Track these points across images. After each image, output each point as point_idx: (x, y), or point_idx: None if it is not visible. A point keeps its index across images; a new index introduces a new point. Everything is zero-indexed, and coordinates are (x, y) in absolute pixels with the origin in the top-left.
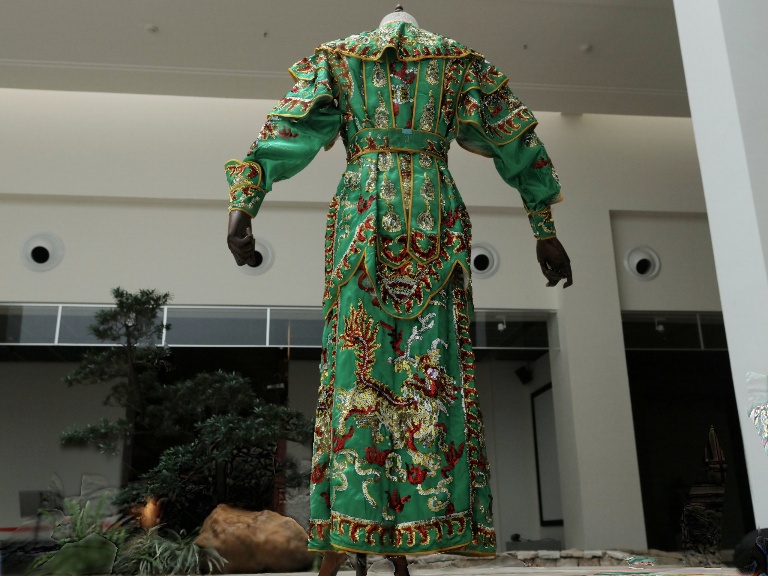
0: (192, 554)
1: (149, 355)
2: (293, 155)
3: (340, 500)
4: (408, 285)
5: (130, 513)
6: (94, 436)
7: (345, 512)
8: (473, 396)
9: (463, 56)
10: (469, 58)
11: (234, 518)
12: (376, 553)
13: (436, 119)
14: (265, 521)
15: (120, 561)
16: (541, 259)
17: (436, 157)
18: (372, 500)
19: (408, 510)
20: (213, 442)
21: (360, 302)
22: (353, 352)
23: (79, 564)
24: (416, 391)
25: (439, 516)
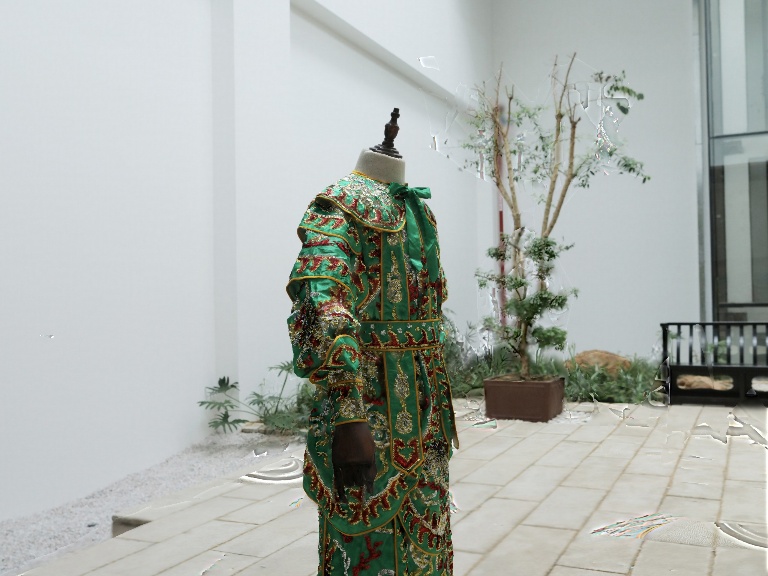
0: None
1: None
2: None
3: None
4: None
5: None
6: None
7: None
8: None
9: None
10: None
11: None
12: None
13: None
14: None
15: None
16: None
17: None
18: None
19: None
20: None
21: None
22: None
23: None
24: None
25: None
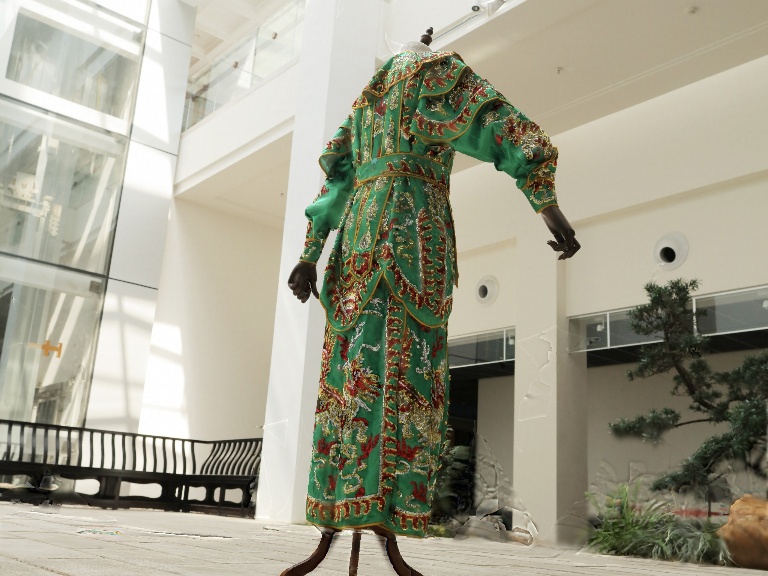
0: (704, 543)
1: (681, 344)
2: (322, 208)
3: None
4: None
5: (663, 499)
6: (639, 426)
7: None
8: (391, 392)
9: (419, 69)
10: (427, 67)
11: (750, 509)
12: (318, 525)
13: (396, 140)
14: None
15: (636, 543)
16: None
17: (395, 175)
18: (317, 482)
19: None
20: (734, 429)
21: None
22: None
23: (561, 539)
24: (347, 391)
25: (350, 498)
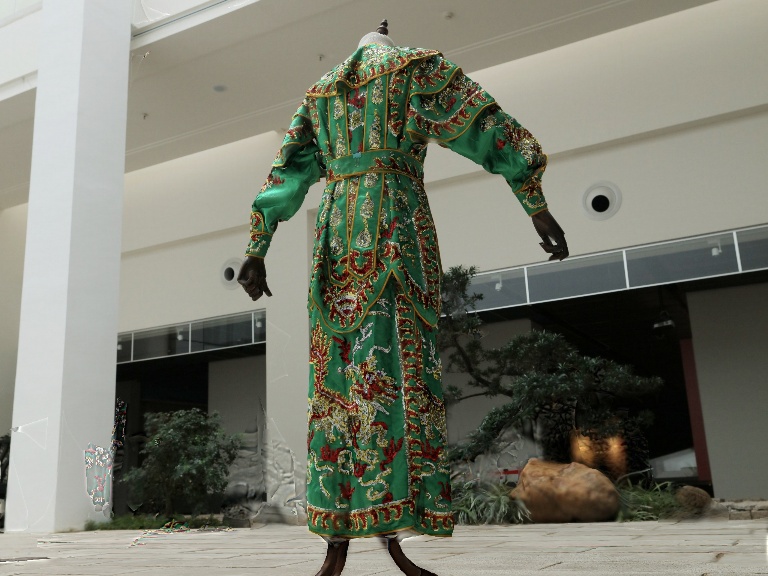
0: None
1: (463, 326)
2: (279, 200)
3: (308, 492)
4: (352, 301)
5: (457, 469)
6: None
7: (310, 502)
8: (412, 394)
9: (406, 65)
10: (414, 64)
11: (540, 471)
12: (331, 536)
13: (383, 135)
14: (570, 473)
15: None
16: (540, 234)
17: (385, 172)
18: (326, 492)
19: (354, 499)
20: (519, 401)
21: (318, 322)
22: (313, 366)
23: None
24: (357, 395)
25: (376, 504)
